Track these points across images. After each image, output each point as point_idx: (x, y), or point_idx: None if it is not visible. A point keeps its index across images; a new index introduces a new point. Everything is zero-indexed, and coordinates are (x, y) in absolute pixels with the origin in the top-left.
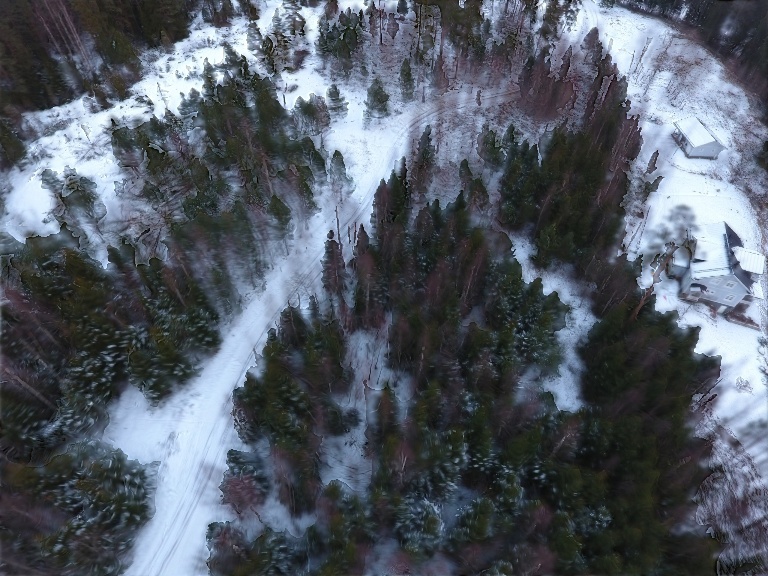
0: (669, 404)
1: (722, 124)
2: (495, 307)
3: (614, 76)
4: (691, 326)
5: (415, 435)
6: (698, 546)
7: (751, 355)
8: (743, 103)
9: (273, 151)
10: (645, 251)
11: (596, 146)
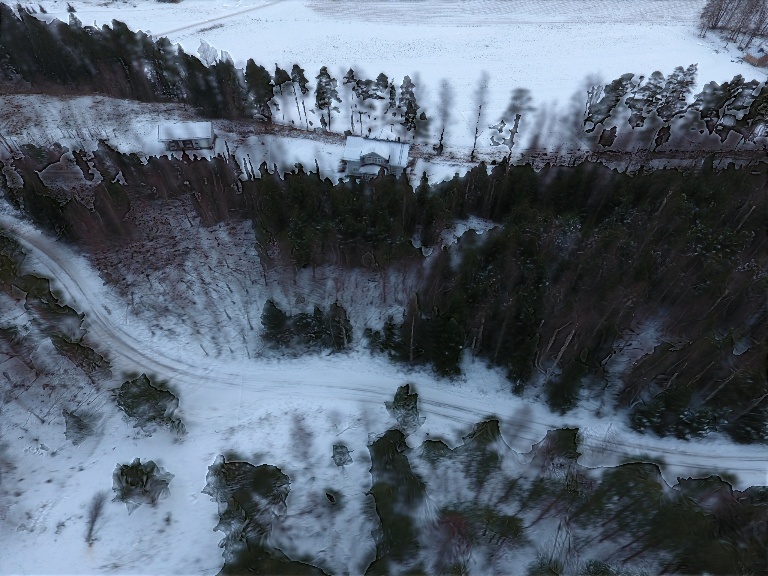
0: (586, 168)
1: (151, 121)
2: (546, 247)
3: (80, 152)
4: (434, 184)
5: (716, 275)
6: (662, 173)
7: (441, 167)
8: (116, 101)
9: (417, 511)
10: None
11: (250, 181)
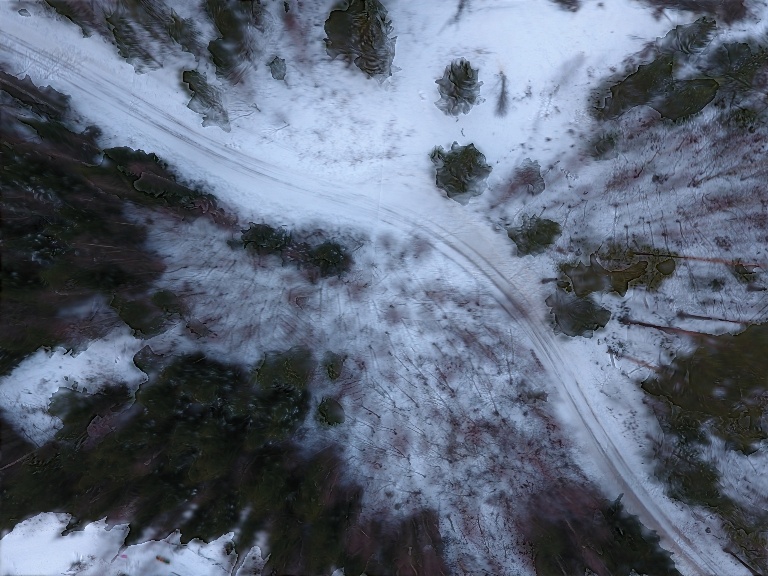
0: None
1: None
2: None
3: None
4: (75, 566)
5: None
6: None
7: None
8: None
9: None
10: (206, 568)
11: None
